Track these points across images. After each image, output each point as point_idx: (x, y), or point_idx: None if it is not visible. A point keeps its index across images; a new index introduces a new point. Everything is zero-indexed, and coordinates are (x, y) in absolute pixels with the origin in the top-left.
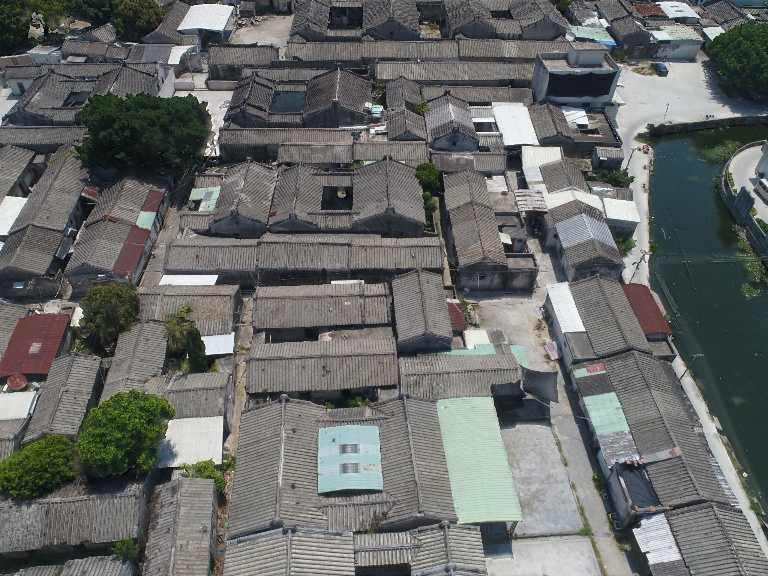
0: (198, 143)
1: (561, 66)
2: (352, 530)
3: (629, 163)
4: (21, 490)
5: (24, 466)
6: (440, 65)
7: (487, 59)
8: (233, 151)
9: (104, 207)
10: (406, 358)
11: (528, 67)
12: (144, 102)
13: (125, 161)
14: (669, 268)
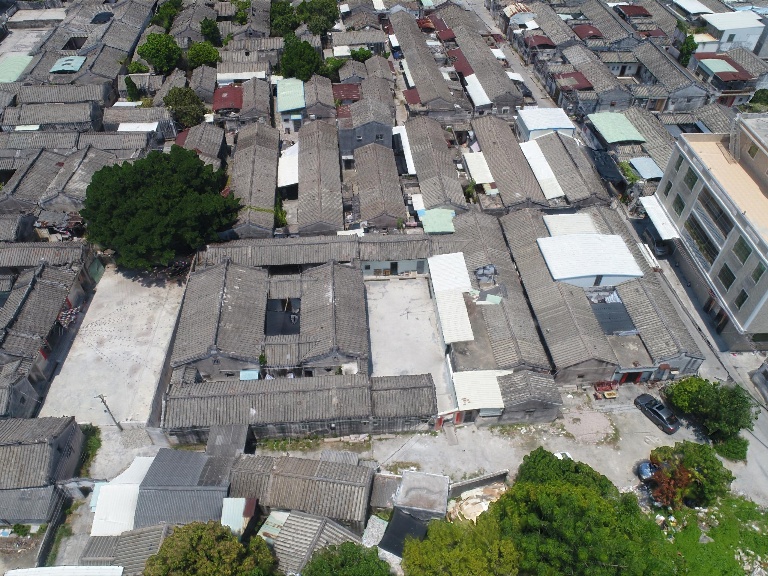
0: None
1: None
2: None
3: None
4: None
5: None
6: None
7: None
8: None
9: None
10: None
11: None
12: None
13: None
14: None
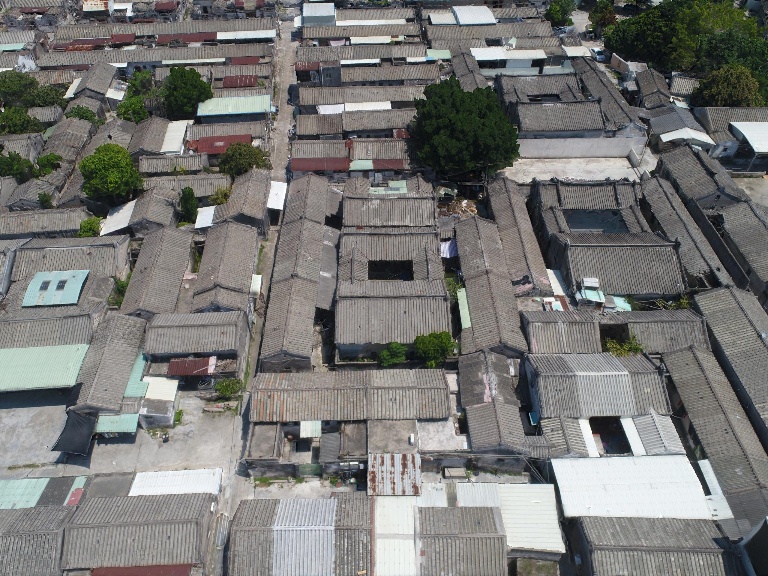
0: None
1: None
2: (7, 295)
3: None
4: None
5: None
6: None
7: None
8: None
9: None
10: (143, 324)
11: None
12: (455, 101)
13: None
14: None
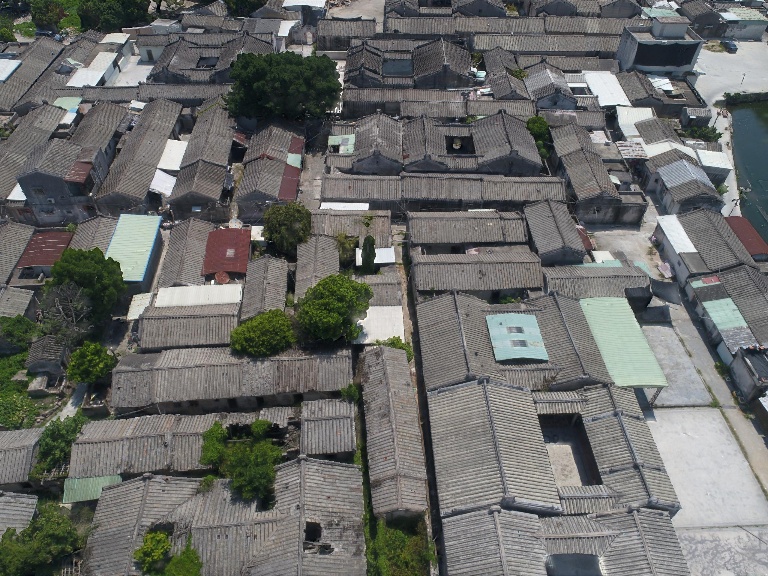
0: (334, 96)
1: (647, 38)
2: None
3: (711, 125)
4: (259, 348)
5: (260, 329)
6: (532, 38)
7: (571, 34)
8: (355, 108)
9: (258, 148)
10: (547, 268)
11: (612, 40)
12: (290, 58)
13: (271, 110)
14: (756, 213)
